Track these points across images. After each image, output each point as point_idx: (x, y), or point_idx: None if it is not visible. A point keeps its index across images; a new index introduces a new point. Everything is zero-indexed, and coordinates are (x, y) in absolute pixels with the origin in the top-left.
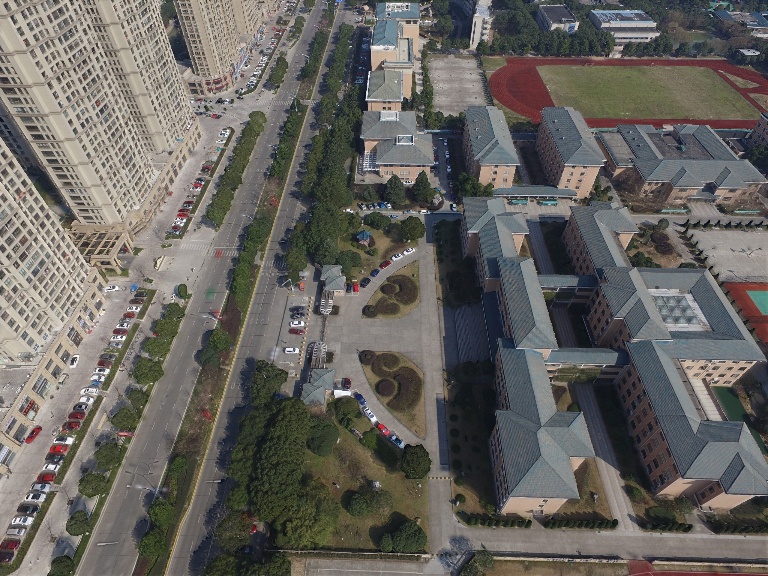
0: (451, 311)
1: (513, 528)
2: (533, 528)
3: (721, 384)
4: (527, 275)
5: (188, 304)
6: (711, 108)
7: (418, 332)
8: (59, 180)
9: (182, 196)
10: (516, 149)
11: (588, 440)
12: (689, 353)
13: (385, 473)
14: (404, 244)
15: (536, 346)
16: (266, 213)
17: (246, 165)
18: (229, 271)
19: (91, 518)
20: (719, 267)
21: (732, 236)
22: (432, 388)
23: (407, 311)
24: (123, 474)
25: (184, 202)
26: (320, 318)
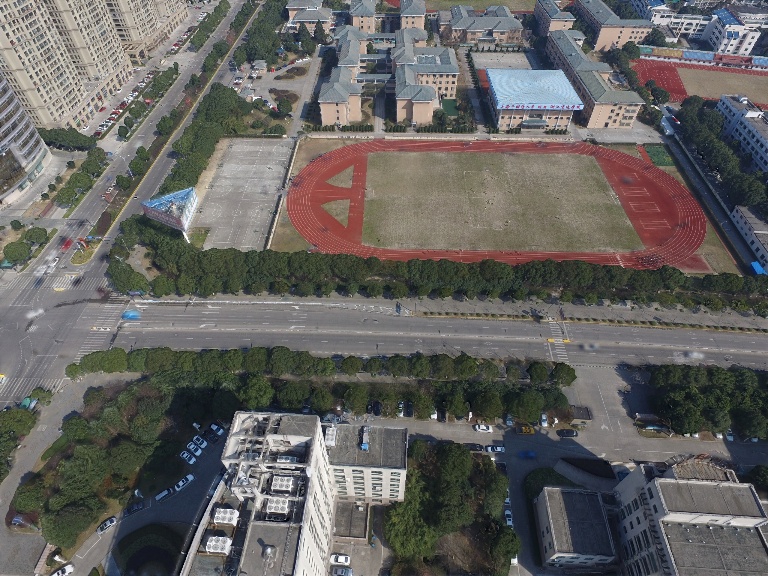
0: (322, 78)
1: (327, 132)
2: (336, 132)
3: (449, 97)
4: (353, 44)
5: (179, 76)
6: (525, 6)
7: (302, 84)
8: (108, 7)
9: (176, 39)
10: (388, 22)
11: (360, 89)
12: (423, 70)
13: (273, 120)
14: (305, 57)
15: (347, 64)
16: (225, 42)
17: (215, 25)
18: (202, 66)
19: (133, 130)
20: (479, 65)
21: (495, 55)
22: (304, 99)
23: (299, 78)
24: (147, 121)
25: (177, 41)
26: (251, 80)
